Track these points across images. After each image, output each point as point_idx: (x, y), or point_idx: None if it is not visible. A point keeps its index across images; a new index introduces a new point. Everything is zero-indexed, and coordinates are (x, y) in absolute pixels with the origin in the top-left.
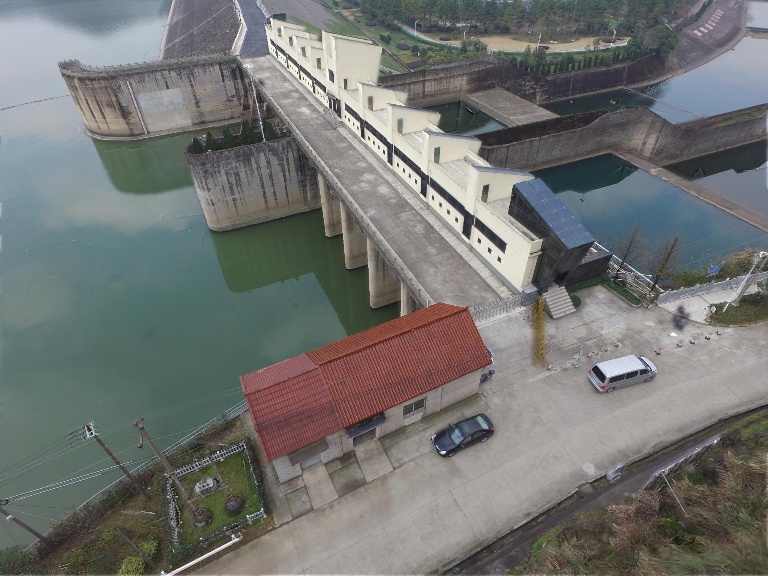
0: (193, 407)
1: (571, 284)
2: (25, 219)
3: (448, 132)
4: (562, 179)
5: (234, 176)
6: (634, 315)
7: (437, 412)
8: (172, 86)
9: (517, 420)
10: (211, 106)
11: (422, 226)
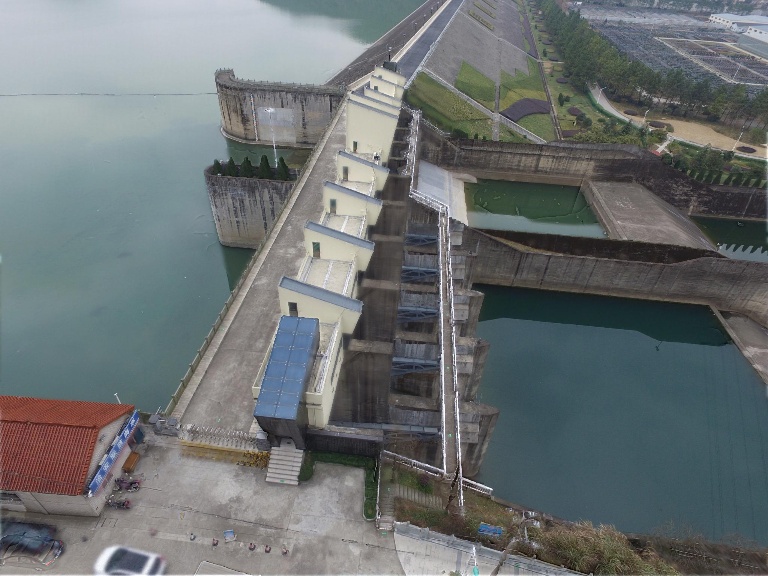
0: (58, 389)
1: (326, 451)
2: (121, 185)
3: (558, 215)
4: (627, 314)
5: (239, 202)
6: (352, 528)
7: (45, 513)
8: (286, 106)
9: (92, 569)
10: (316, 130)
11: None
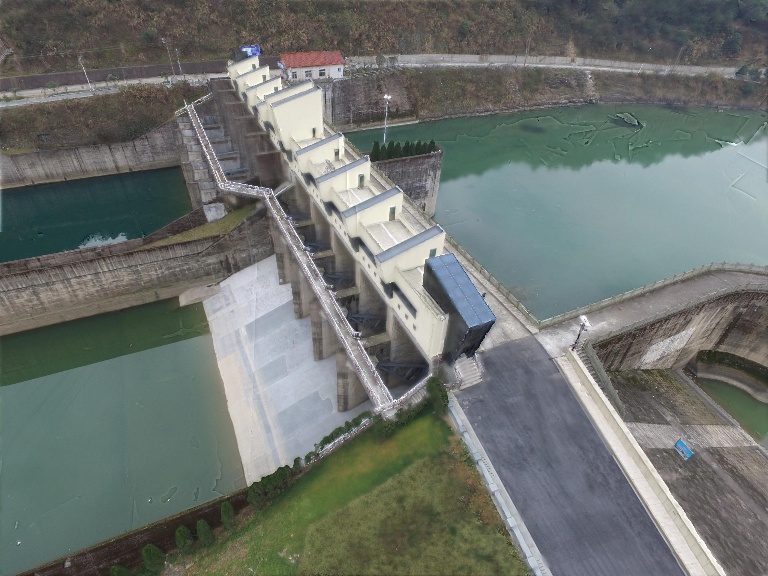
0: None
1: None
2: (602, 228)
3: None
4: None
5: None
6: None
7: None
8: None
9: None
10: None
11: None
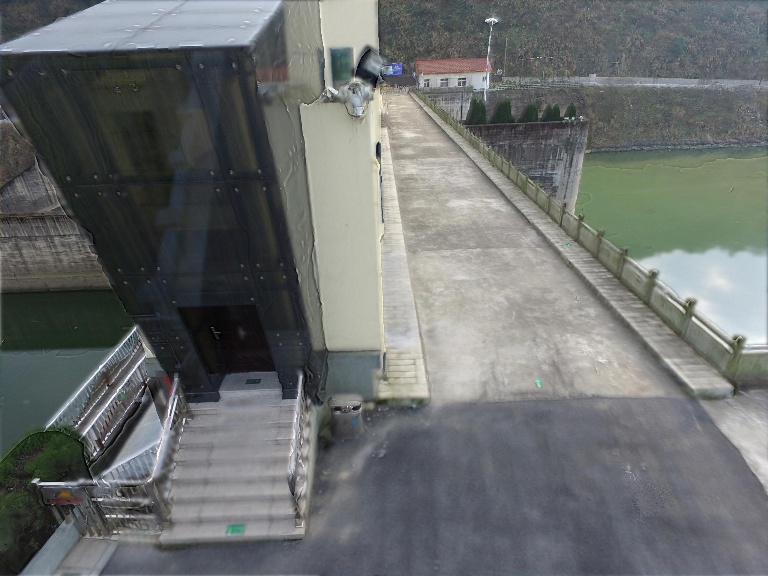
0: None
1: None
2: None
3: None
4: None
5: None
6: None
7: None
8: None
9: None
10: None
11: None
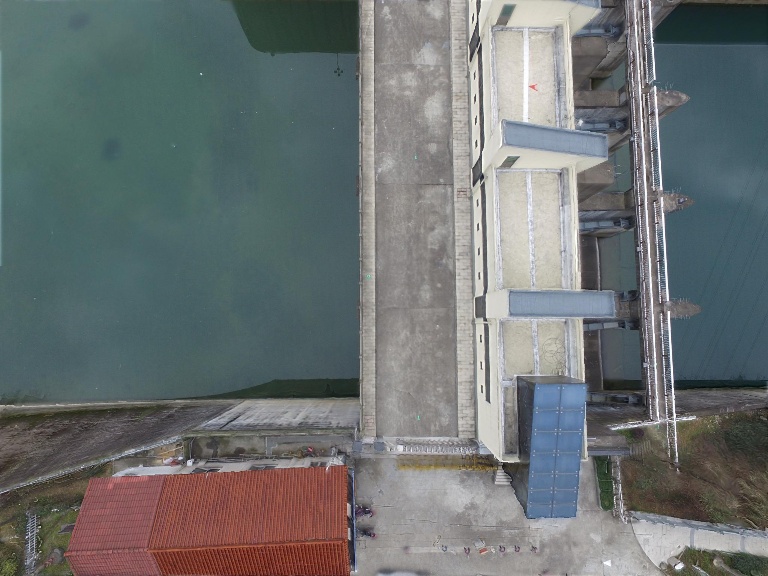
0: (141, 284)
1: None
2: None
3: None
4: None
5: None
6: (590, 518)
7: None
8: None
9: None
10: None
11: (442, 233)
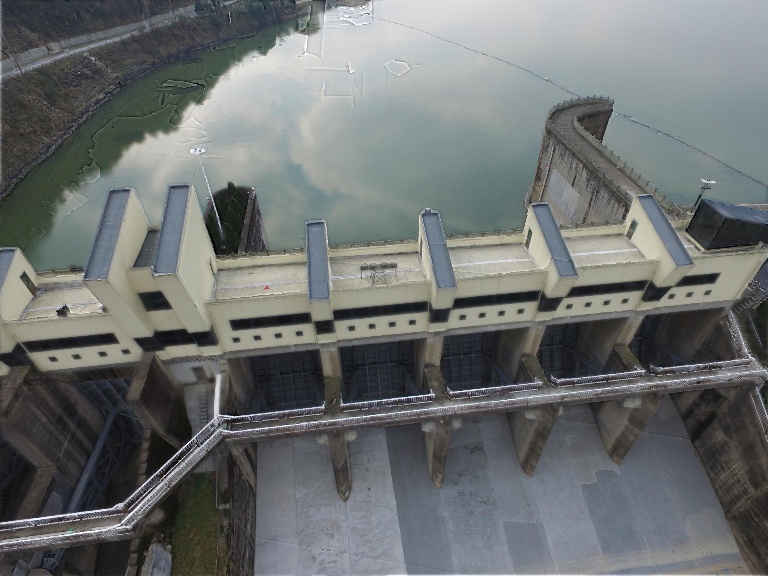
0: None
1: None
2: (360, 171)
3: None
4: None
5: None
6: None
7: None
8: (577, 187)
9: None
10: None
11: None
